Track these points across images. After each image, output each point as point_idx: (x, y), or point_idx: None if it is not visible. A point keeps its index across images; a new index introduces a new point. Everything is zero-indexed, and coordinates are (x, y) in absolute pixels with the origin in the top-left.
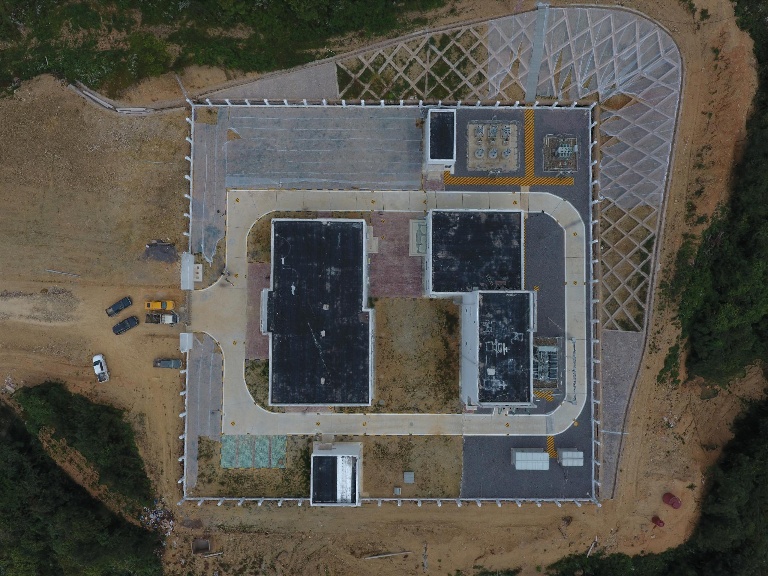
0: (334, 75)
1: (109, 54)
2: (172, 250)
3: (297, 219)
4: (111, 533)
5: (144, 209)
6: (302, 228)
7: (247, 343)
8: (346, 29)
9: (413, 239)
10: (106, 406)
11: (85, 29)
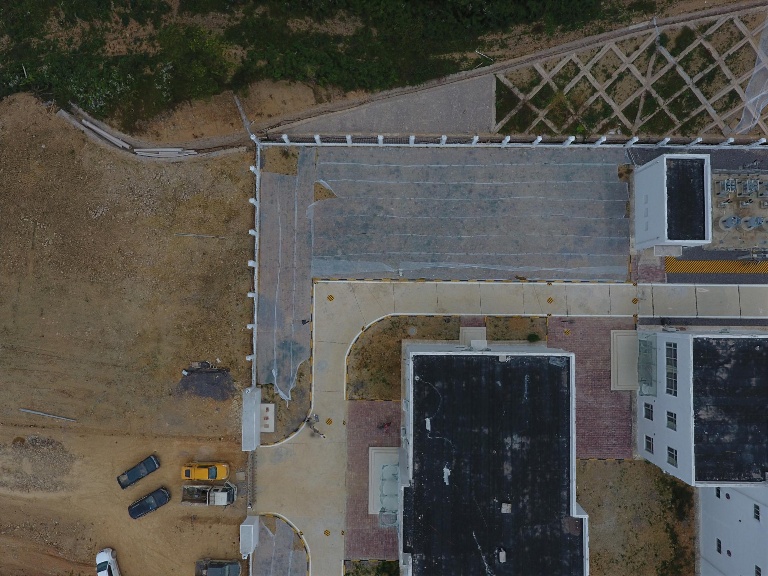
0: (490, 95)
1: (124, 62)
2: (225, 379)
3: (455, 353)
4: None
5: (179, 311)
6: (461, 366)
7: (347, 533)
8: (512, 20)
9: (618, 363)
10: None
11: (85, 21)
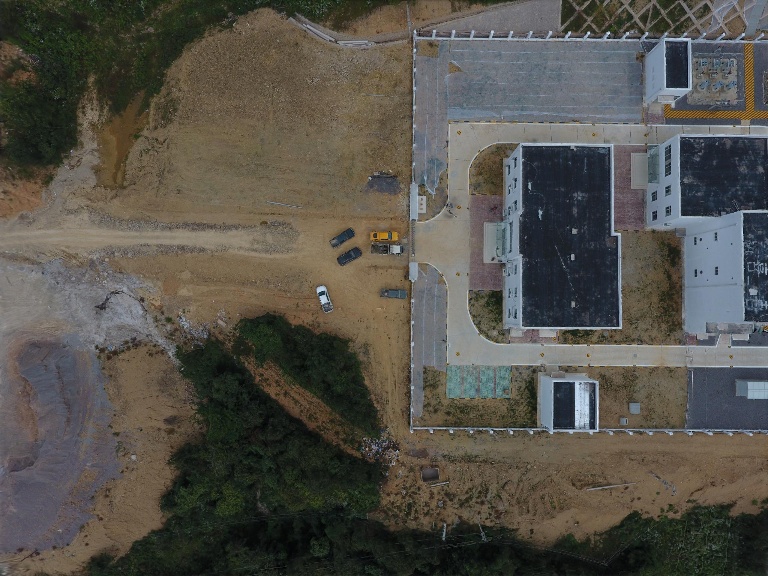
0: (558, 7)
1: None
2: (395, 182)
3: (546, 143)
4: (340, 461)
5: (365, 141)
6: (548, 153)
7: (470, 274)
8: None
9: (636, 172)
10: (332, 336)
11: None
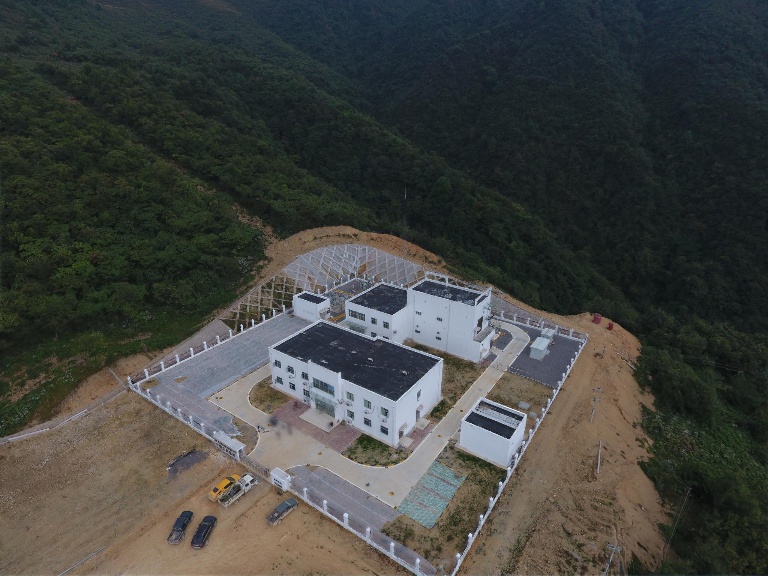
0: (223, 325)
1: (34, 390)
2: (196, 453)
3: (284, 339)
4: None
5: (140, 455)
6: (291, 343)
7: (329, 446)
8: (210, 310)
9: None
10: None
11: None
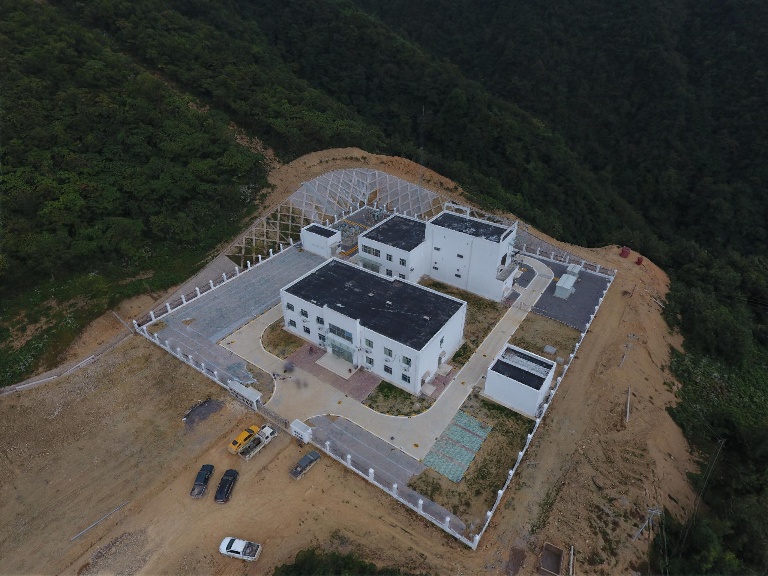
0: (228, 261)
1: (36, 336)
2: (212, 402)
3: (296, 280)
4: None
5: (153, 404)
6: (304, 284)
7: (348, 394)
8: (214, 244)
9: None
10: None
11: None
